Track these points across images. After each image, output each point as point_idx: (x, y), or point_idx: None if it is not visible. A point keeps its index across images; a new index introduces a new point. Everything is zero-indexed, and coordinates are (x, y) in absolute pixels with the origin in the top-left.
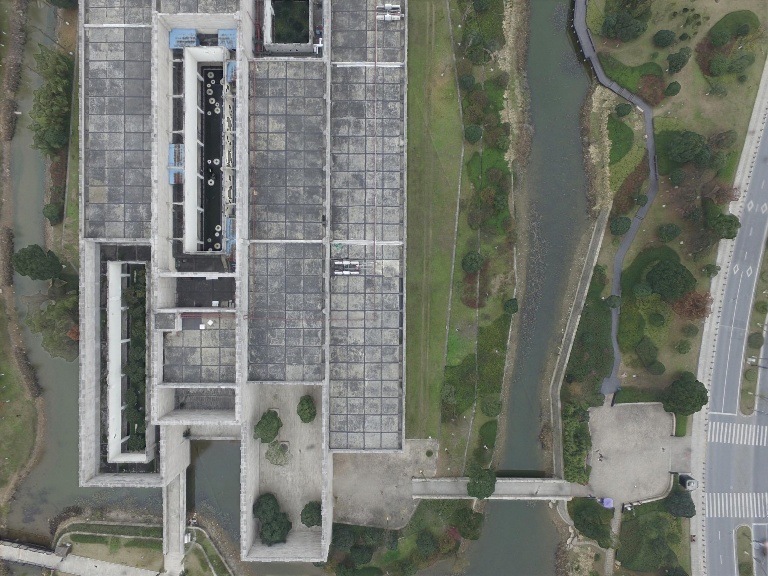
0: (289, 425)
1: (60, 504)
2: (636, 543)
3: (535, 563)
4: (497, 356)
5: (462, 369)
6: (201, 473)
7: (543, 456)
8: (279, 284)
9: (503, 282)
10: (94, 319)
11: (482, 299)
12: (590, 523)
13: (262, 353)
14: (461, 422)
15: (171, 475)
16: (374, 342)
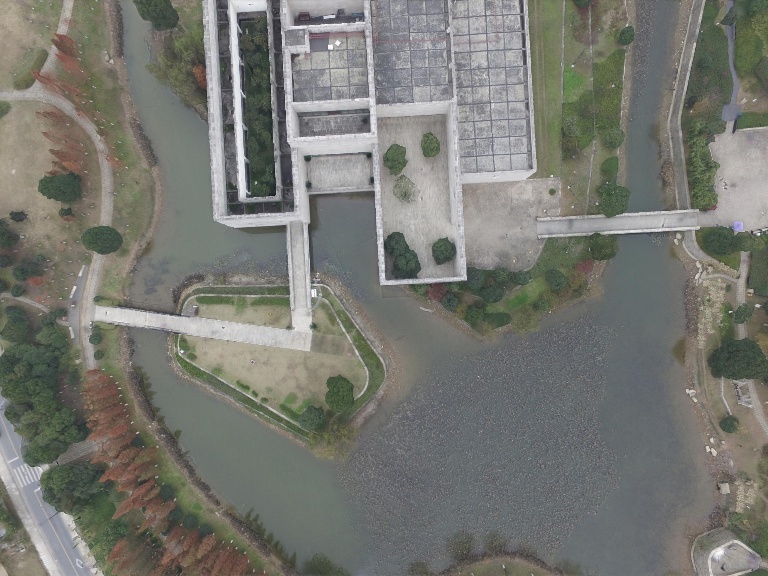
0: (409, 173)
1: (181, 273)
2: (767, 269)
3: (664, 303)
4: (614, 91)
5: (580, 105)
6: (321, 233)
7: (665, 193)
8: (401, 7)
9: (614, 18)
10: (216, 61)
11: (595, 35)
12: (727, 235)
13: (388, 77)
14: (582, 160)
15: (302, 211)
16: (498, 64)
